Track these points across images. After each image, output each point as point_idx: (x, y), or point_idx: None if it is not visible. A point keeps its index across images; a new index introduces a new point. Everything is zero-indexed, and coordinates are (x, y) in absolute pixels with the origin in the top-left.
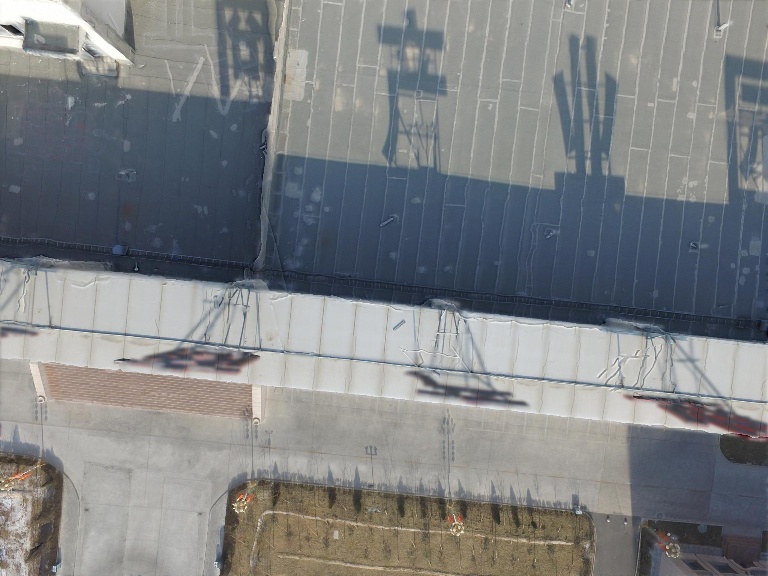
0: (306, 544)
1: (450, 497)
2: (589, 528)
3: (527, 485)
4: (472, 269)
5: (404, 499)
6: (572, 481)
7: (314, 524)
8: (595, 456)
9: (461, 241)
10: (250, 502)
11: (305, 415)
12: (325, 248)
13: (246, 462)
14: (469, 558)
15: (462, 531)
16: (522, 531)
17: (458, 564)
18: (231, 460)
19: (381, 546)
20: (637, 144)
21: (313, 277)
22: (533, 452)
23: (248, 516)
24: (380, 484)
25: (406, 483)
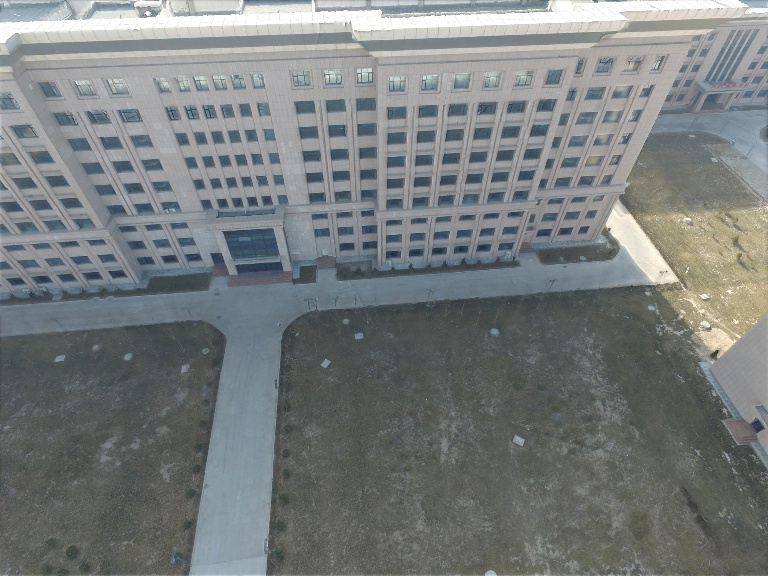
0: None
1: None
2: None
3: None
4: None
5: None
6: None
7: None
8: None
9: None
10: None
11: None
12: None
13: None
14: None
15: None
16: None
17: None
18: None
19: None
20: None
21: (50, 7)
22: None
23: None
24: None
25: None
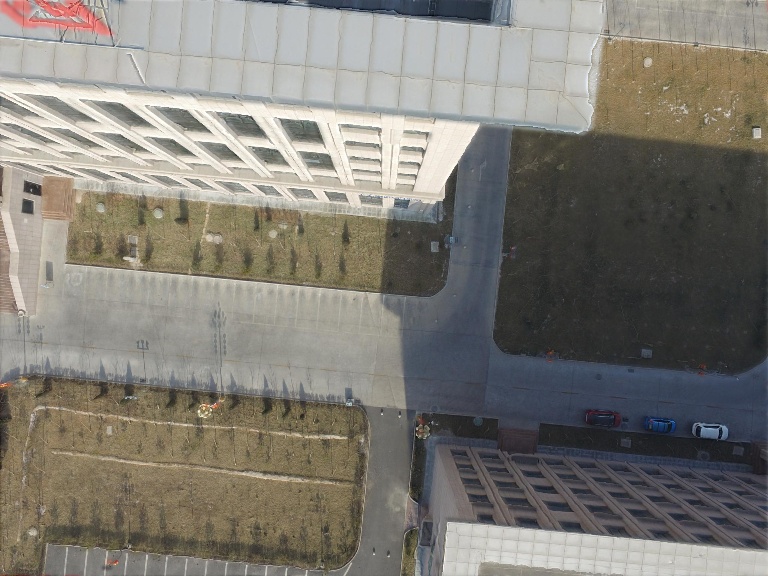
0: (80, 440)
1: (222, 391)
2: (363, 422)
3: (300, 379)
4: None
5: (174, 392)
6: (345, 374)
7: (87, 420)
8: (367, 349)
9: None
10: (22, 397)
11: (76, 310)
12: None
13: (18, 357)
14: (244, 453)
15: (207, 412)
16: (296, 425)
17: (233, 460)
18: (3, 355)
19: (155, 442)
20: None
21: None
22: (305, 345)
23: (20, 411)
24: (152, 379)
25: (178, 377)
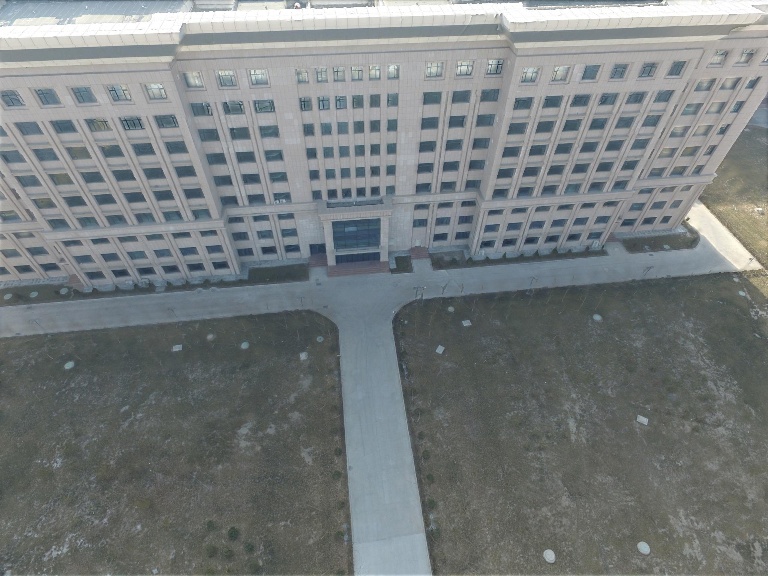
0: None
1: None
2: None
3: None
4: (117, 4)
5: None
6: None
7: None
8: None
9: (120, 7)
10: None
11: None
12: (167, 3)
13: None
14: None
15: None
16: None
17: None
18: None
19: None
20: (47, 23)
21: None
22: None
23: None
24: None
25: None
